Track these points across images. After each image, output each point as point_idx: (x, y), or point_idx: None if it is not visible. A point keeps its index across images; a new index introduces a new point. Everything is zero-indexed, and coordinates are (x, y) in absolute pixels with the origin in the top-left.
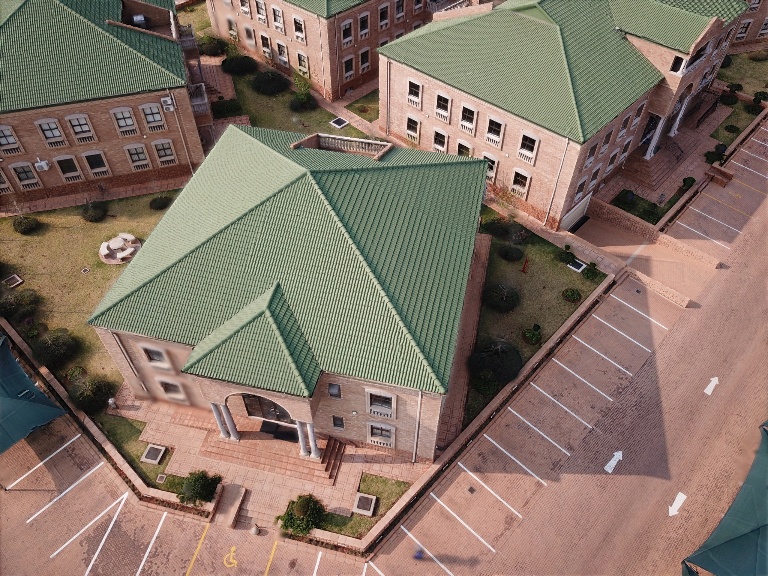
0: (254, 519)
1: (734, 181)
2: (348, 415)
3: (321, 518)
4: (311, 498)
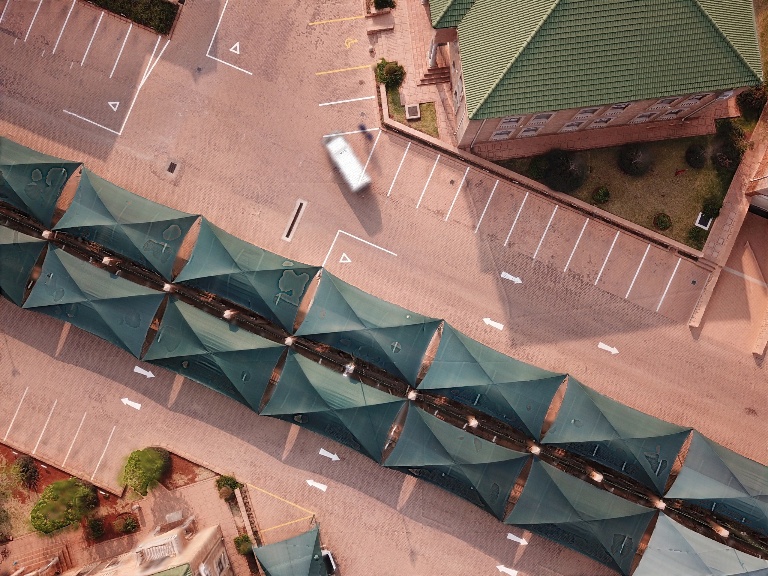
0: (378, 44)
1: None
2: (456, 68)
3: (393, 87)
4: (403, 74)
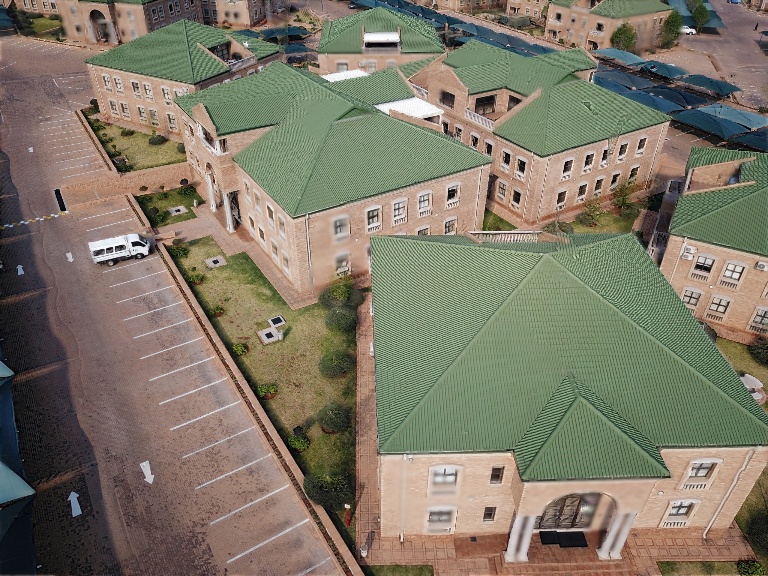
0: None
1: None
2: None
3: None
4: None
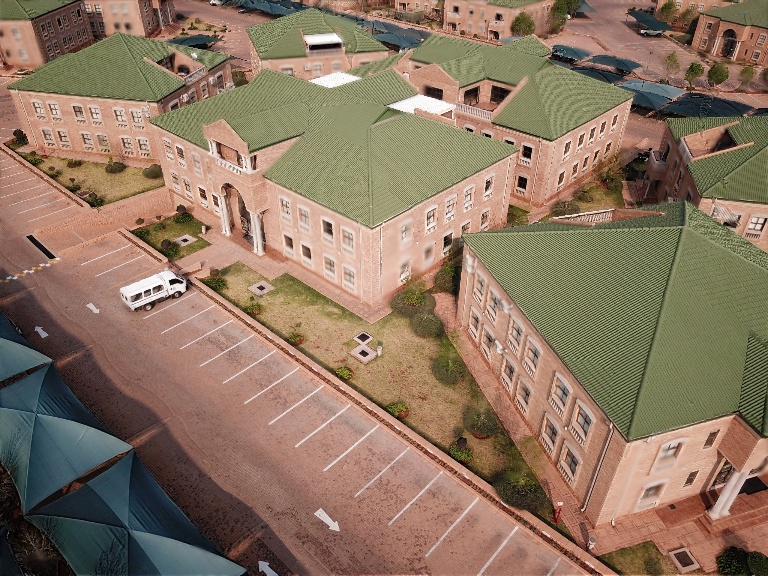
0: None
1: None
2: None
3: None
4: None
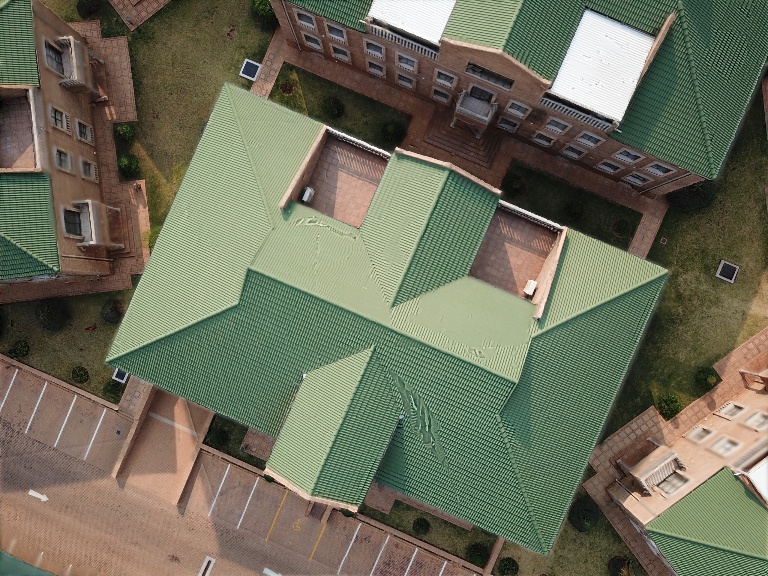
0: None
1: (322, 525)
2: None
3: None
4: None
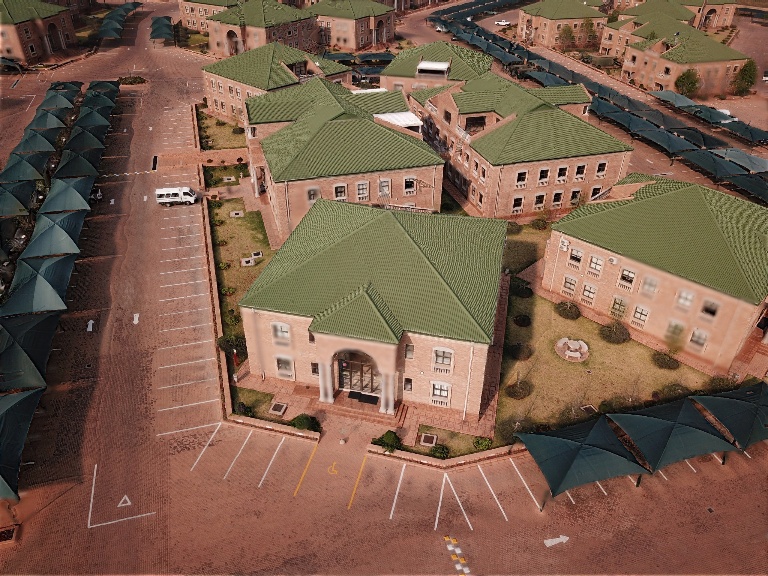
0: None
1: None
2: None
3: None
4: None
